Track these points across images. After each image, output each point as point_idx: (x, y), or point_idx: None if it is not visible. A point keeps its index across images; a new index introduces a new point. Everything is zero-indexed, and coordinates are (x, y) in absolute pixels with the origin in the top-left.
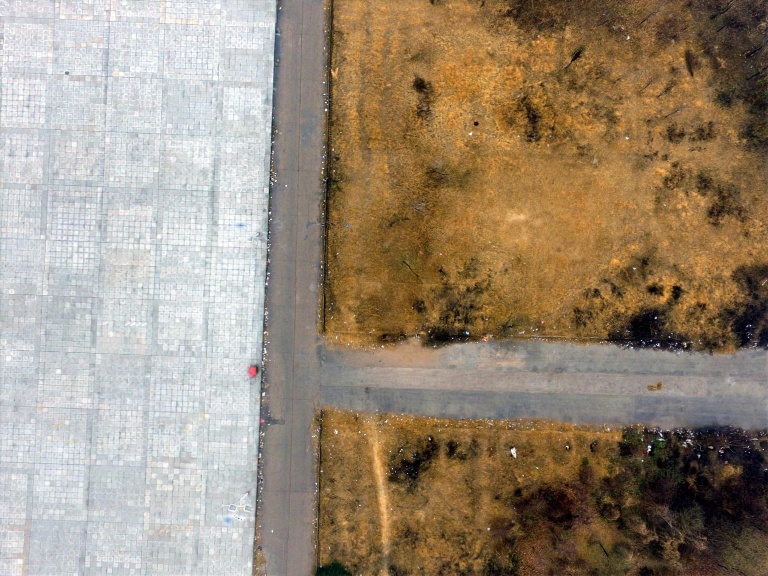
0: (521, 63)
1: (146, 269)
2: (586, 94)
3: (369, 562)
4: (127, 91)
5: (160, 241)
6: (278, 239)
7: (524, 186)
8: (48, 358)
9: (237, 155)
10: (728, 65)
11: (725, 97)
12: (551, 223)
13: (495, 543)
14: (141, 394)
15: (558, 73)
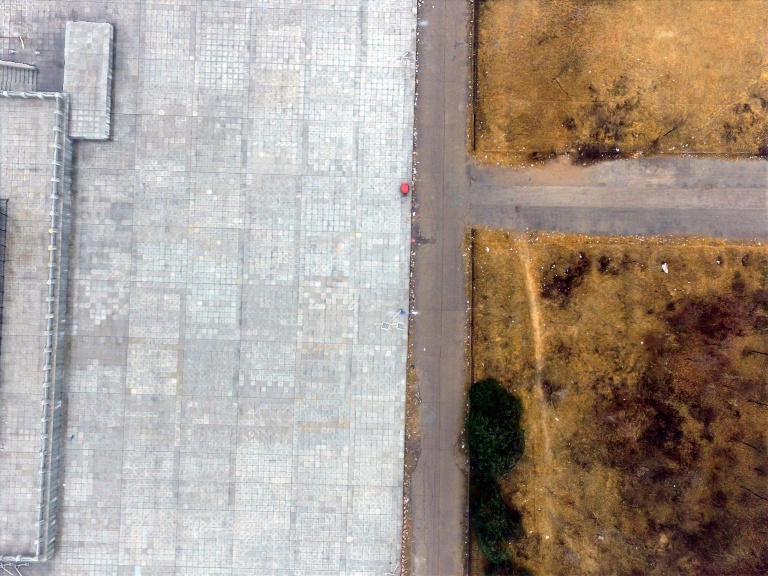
0: None
1: (295, 89)
2: None
3: (523, 378)
4: None
5: (309, 61)
6: (426, 60)
7: (672, 3)
8: (199, 179)
9: None
10: None
11: None
12: (700, 40)
13: (649, 356)
14: (292, 214)
15: None
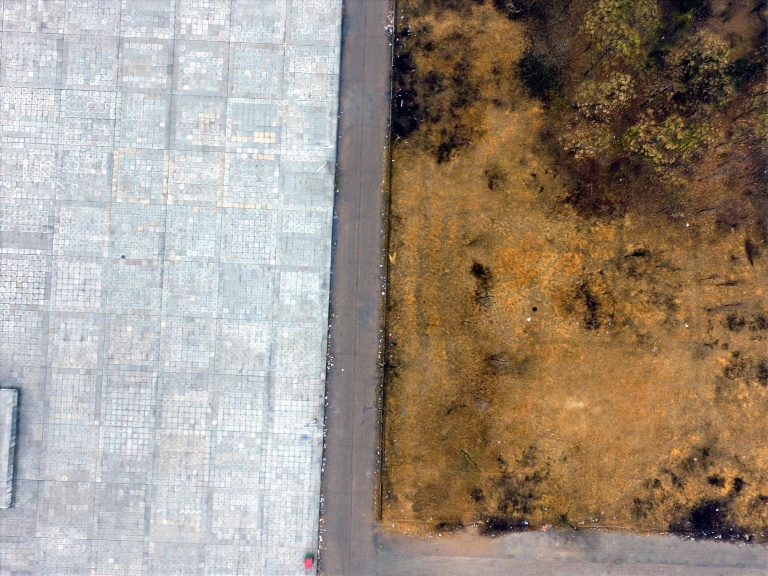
0: (580, 250)
1: (201, 455)
2: (645, 282)
3: None
4: (183, 275)
5: (215, 427)
6: (334, 424)
7: (583, 374)
8: (101, 547)
9: (294, 340)
10: None
11: None
12: (611, 411)
13: None
14: None
15: (617, 260)
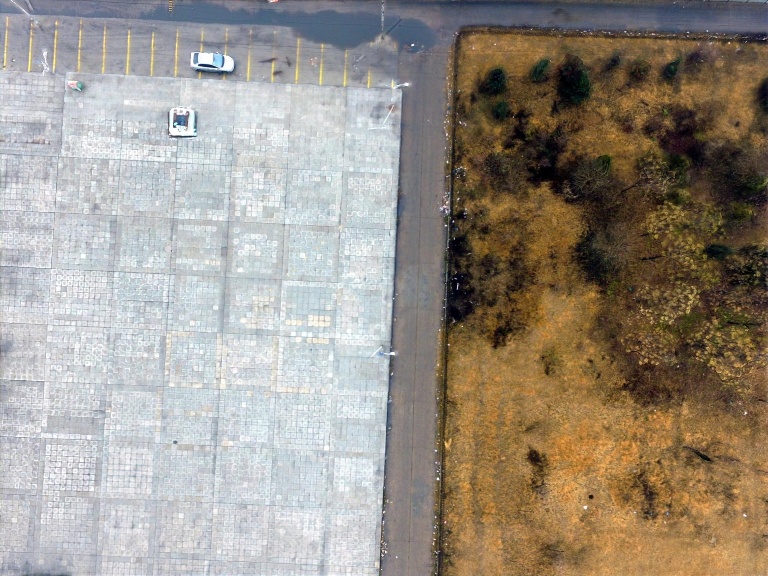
0: (638, 439)
1: None
2: (703, 471)
3: None
4: (236, 461)
5: None
6: None
7: (641, 564)
8: None
9: (348, 528)
10: None
11: None
12: None
13: None
14: None
15: (675, 449)
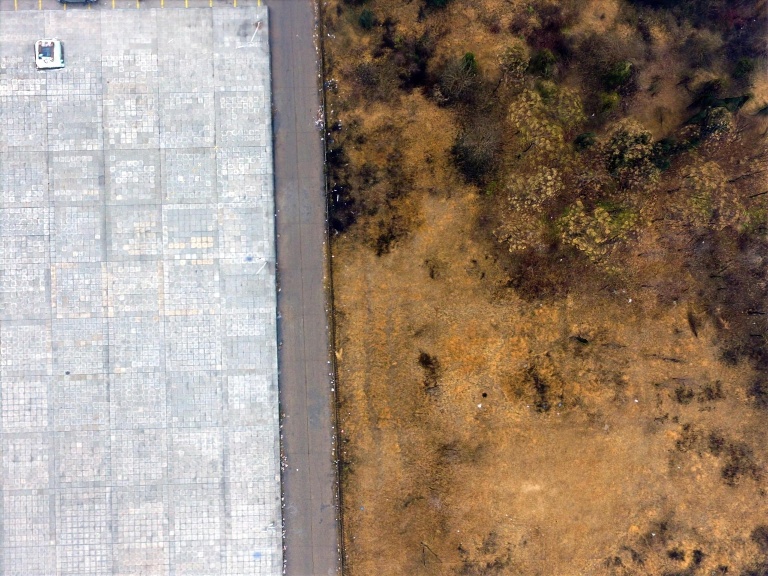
0: (525, 334)
1: (160, 567)
2: (592, 360)
3: None
4: (130, 387)
5: (173, 538)
6: (293, 525)
7: (537, 457)
8: None
9: (246, 444)
10: (731, 324)
11: (730, 354)
12: (567, 492)
13: None
14: None
15: (563, 341)
